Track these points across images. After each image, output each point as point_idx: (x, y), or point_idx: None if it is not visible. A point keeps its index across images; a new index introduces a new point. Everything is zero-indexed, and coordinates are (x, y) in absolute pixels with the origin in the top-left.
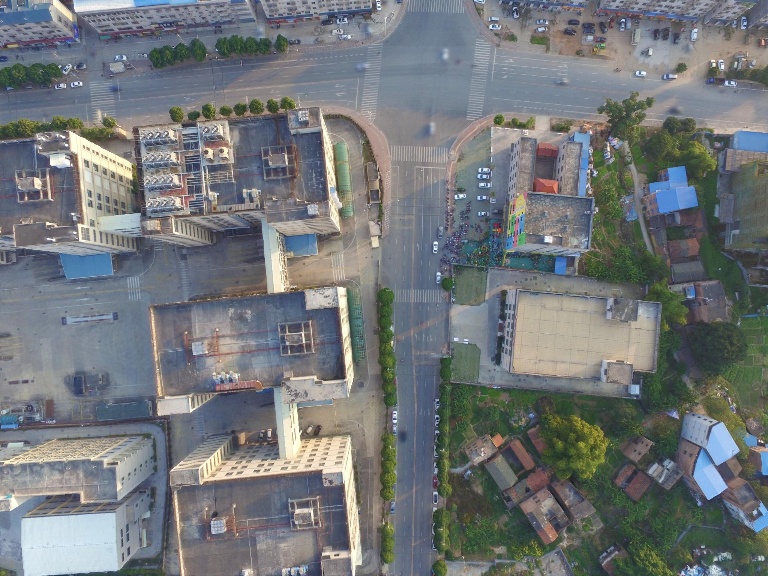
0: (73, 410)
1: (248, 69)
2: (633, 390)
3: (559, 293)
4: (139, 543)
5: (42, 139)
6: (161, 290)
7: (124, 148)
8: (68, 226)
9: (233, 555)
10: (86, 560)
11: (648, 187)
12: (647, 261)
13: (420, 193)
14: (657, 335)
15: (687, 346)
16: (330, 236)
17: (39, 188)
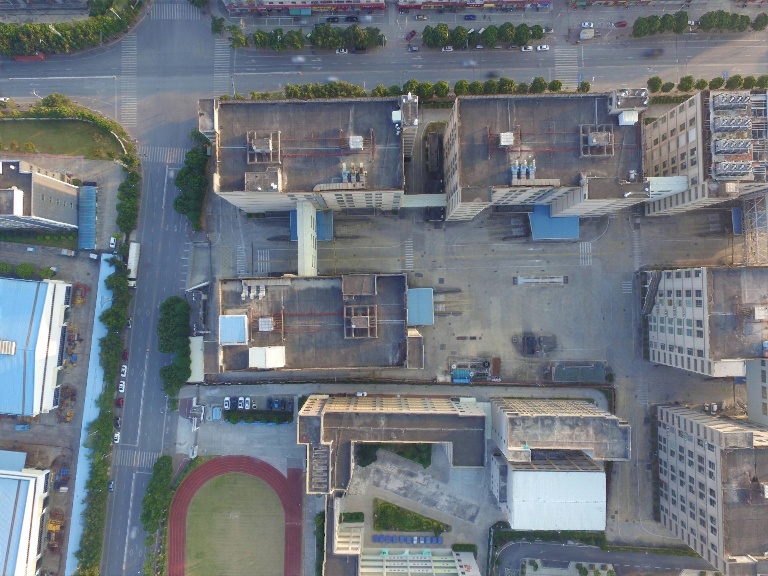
0: (519, 370)
1: (711, 45)
2: None
3: None
4: None
5: (621, 95)
6: (613, 257)
7: None
8: (640, 183)
9: None
10: (575, 517)
11: None
12: None
13: None
14: None
15: None
16: None
17: None
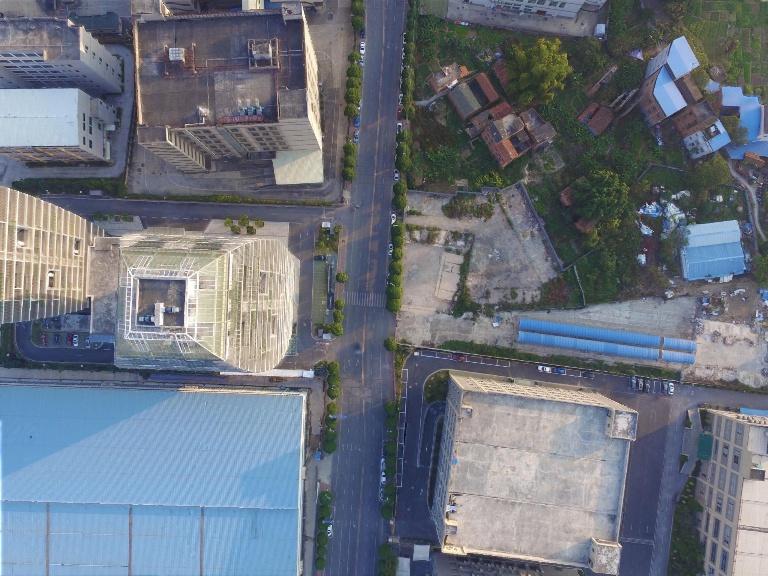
0: None
1: None
2: (599, 28)
3: None
4: (102, 153)
5: None
6: None
7: None
8: None
9: (191, 94)
10: (47, 133)
11: None
12: None
13: None
14: None
15: None
16: None
17: None
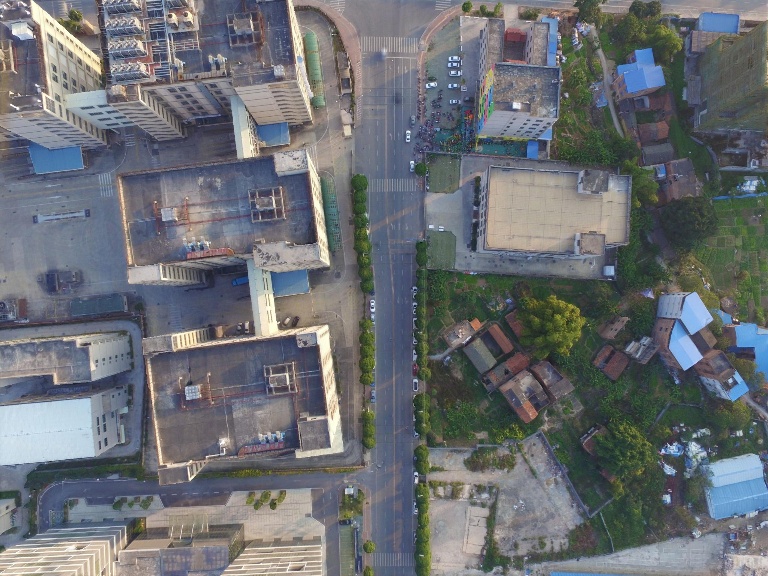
0: (47, 309)
1: None
2: (608, 271)
3: (530, 168)
4: (117, 438)
5: (3, 7)
6: None
7: (92, 44)
8: (32, 95)
9: (209, 424)
10: (62, 447)
11: (616, 70)
12: (618, 143)
13: (391, 83)
14: (628, 207)
15: (660, 227)
16: (302, 128)
17: (2, 59)
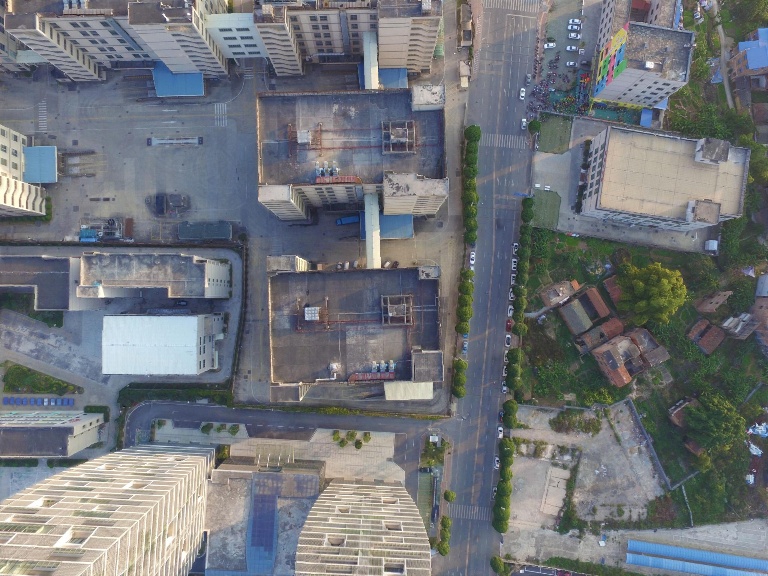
0: (152, 230)
1: None
2: (711, 245)
3: None
4: (211, 363)
5: None
6: (248, 118)
7: None
8: None
9: (322, 348)
10: (165, 361)
11: (737, 46)
12: (732, 118)
13: (510, 40)
14: (744, 180)
15: (766, 206)
16: (419, 76)
17: None
